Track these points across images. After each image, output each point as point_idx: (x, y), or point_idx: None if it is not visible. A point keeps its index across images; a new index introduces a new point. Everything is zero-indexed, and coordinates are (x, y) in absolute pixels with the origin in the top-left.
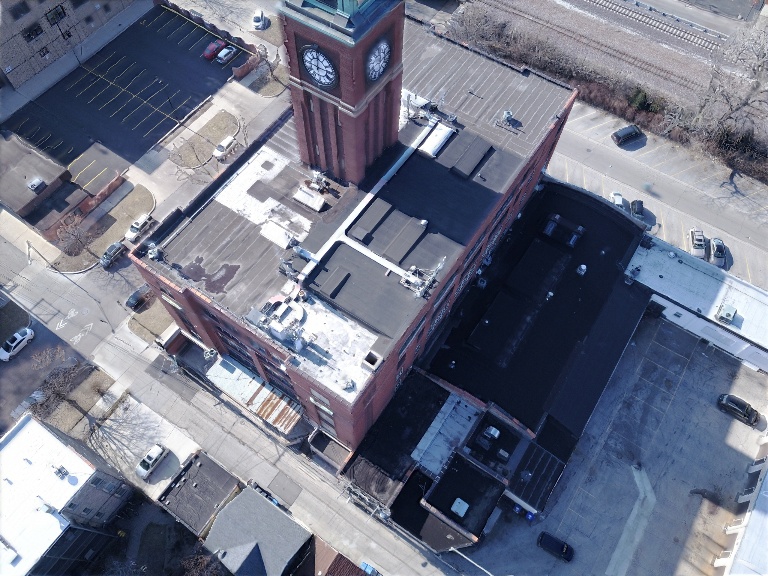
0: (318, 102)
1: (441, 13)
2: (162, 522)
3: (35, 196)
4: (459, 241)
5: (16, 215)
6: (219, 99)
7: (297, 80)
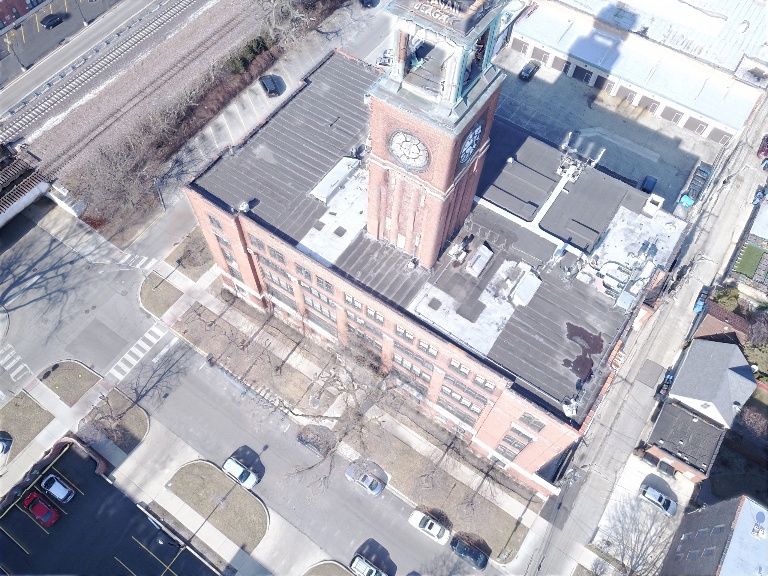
0: None
1: (42, 223)
2: (708, 482)
3: None
4: (523, 140)
5: None
6: (145, 493)
7: (453, 186)
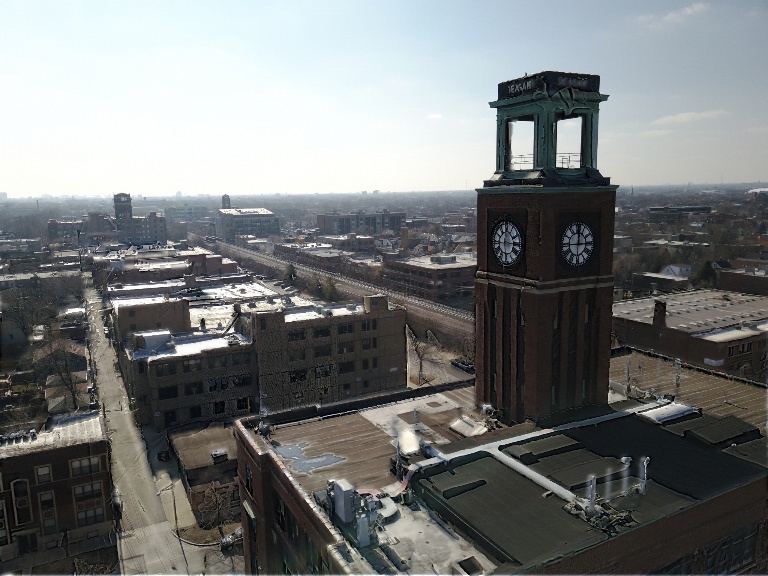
0: (502, 297)
1: None
2: None
3: (211, 464)
4: (687, 493)
5: (185, 480)
6: None
7: (483, 272)
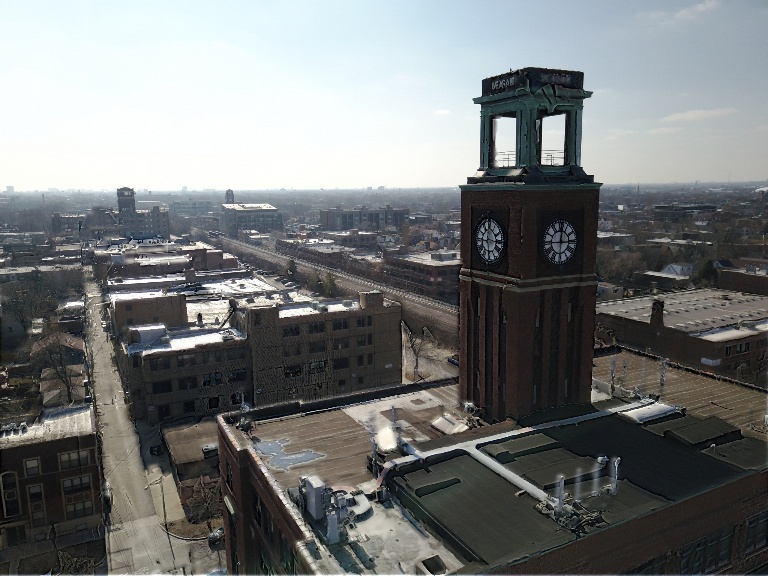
0: (485, 295)
1: None
2: None
3: (202, 459)
4: (661, 494)
5: (176, 475)
6: None
7: (467, 270)
